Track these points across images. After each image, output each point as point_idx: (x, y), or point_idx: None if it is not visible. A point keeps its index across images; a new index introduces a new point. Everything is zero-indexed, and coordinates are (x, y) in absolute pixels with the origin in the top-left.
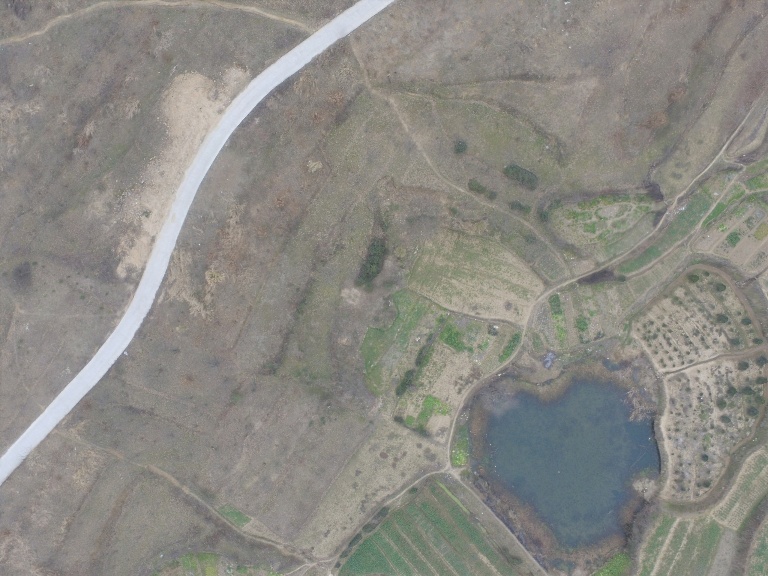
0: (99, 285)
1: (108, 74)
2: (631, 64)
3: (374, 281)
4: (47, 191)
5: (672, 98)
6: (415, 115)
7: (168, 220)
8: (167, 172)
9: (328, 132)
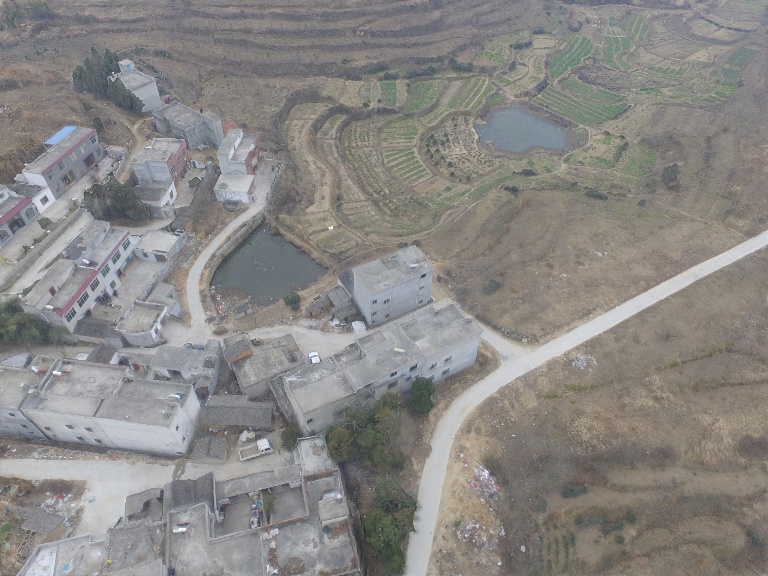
0: None
1: None
2: None
3: None
4: None
5: None
6: None
7: None
8: None
9: None
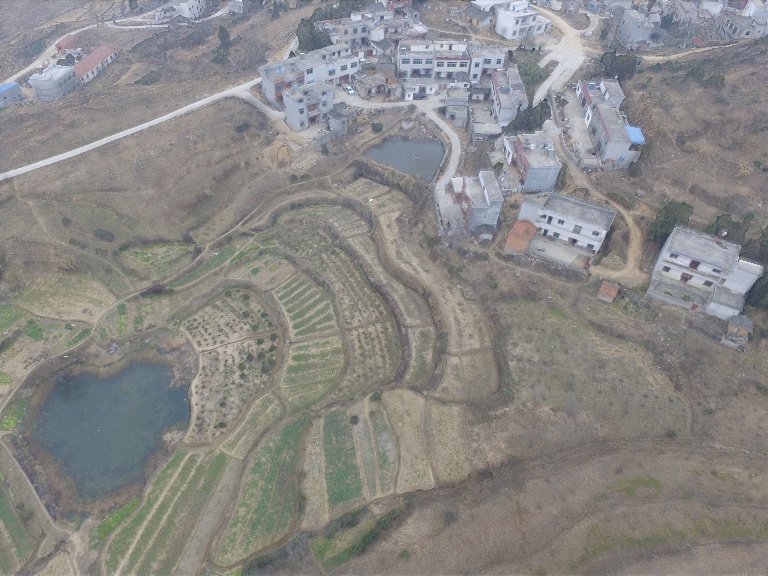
0: None
1: None
2: (176, 186)
3: None
4: None
5: (195, 195)
6: (43, 209)
7: None
8: None
9: None
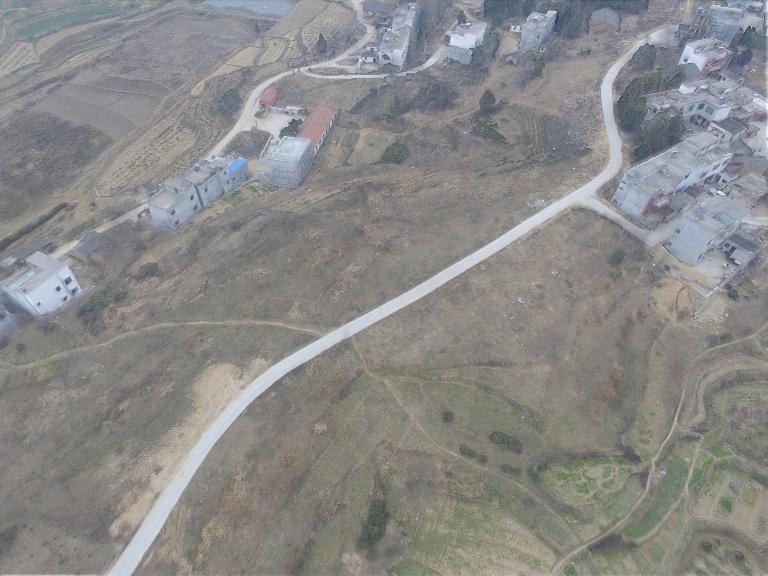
0: (84, 547)
1: (152, 368)
2: (573, 356)
3: (376, 547)
4: (64, 458)
5: (614, 378)
6: (406, 392)
7: (176, 478)
8: (185, 435)
9: (333, 404)
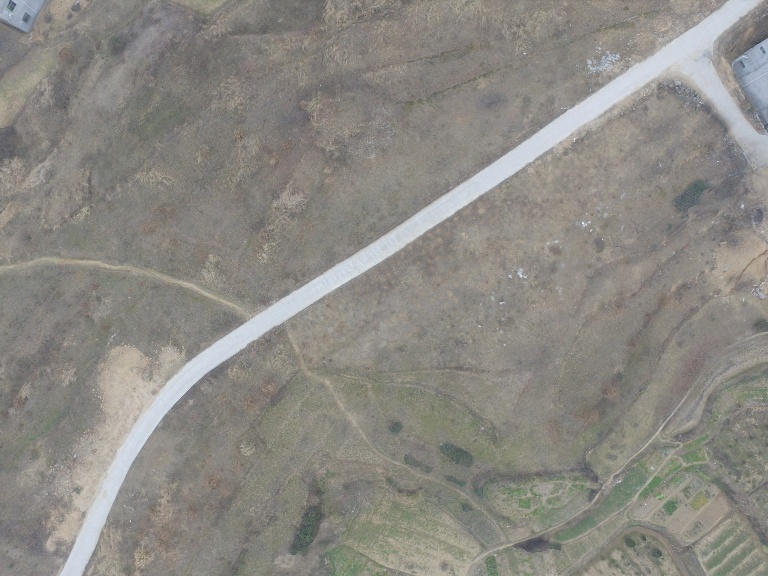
0: (29, 556)
1: (47, 332)
2: (566, 358)
3: None
4: None
5: None
6: (351, 396)
7: (99, 496)
8: (99, 450)
9: (263, 411)
